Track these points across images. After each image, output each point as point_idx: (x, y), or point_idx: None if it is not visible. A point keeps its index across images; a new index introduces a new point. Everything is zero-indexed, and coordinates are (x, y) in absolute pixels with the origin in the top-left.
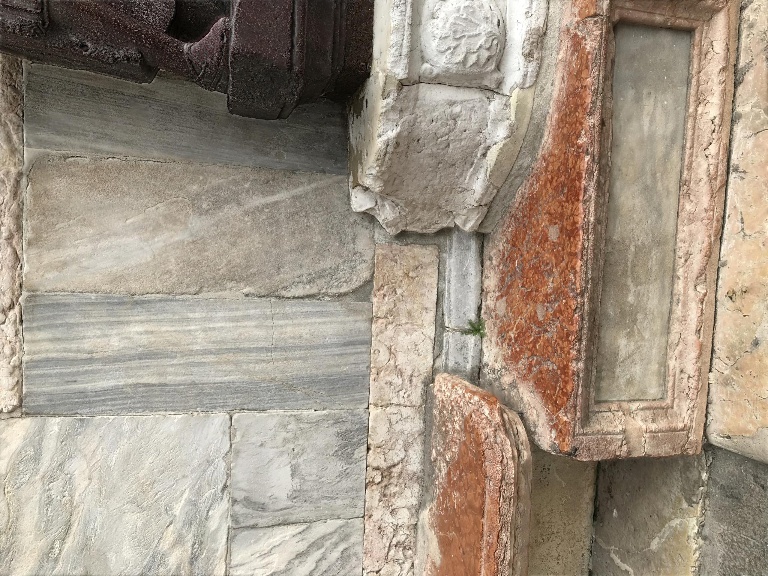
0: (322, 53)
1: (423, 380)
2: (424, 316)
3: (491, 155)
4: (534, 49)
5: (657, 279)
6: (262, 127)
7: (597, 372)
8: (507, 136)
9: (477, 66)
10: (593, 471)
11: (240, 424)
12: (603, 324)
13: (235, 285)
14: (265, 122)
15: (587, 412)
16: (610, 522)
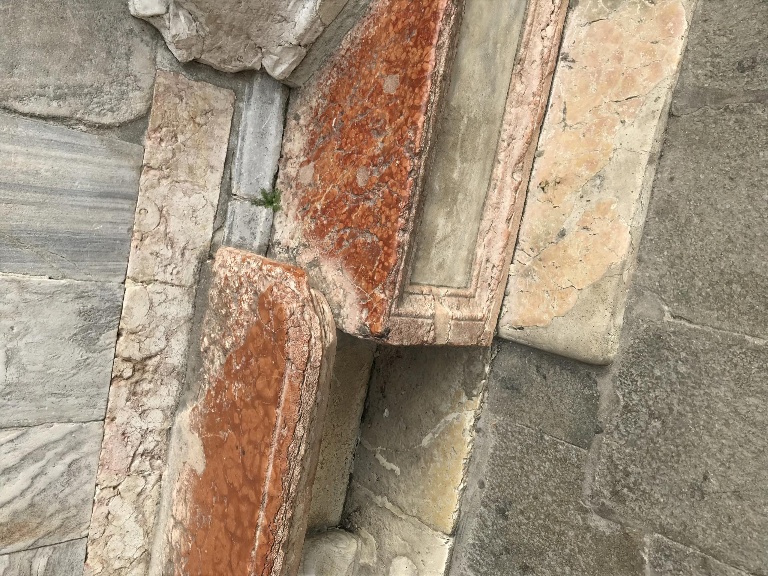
0: None
1: (198, 255)
2: (208, 176)
3: None
4: None
5: (481, 159)
6: None
7: None
8: None
9: None
10: (367, 371)
11: None
12: (428, 198)
13: None
14: None
15: (402, 292)
16: (380, 422)
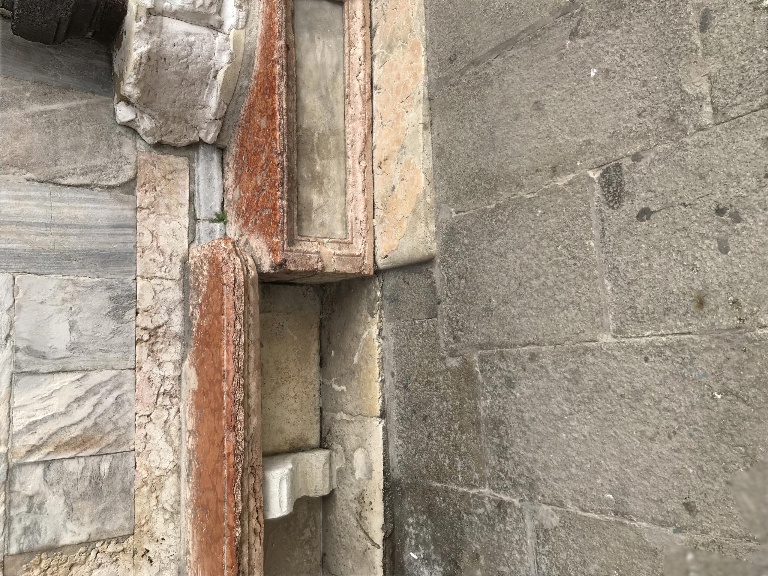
0: None
1: (181, 259)
2: (179, 210)
3: (219, 77)
4: (242, 4)
5: (335, 157)
6: (40, 53)
7: (299, 216)
8: (229, 62)
9: (203, 8)
10: (317, 329)
11: (22, 283)
12: (300, 183)
13: (17, 171)
14: (43, 50)
15: (293, 239)
16: (330, 362)
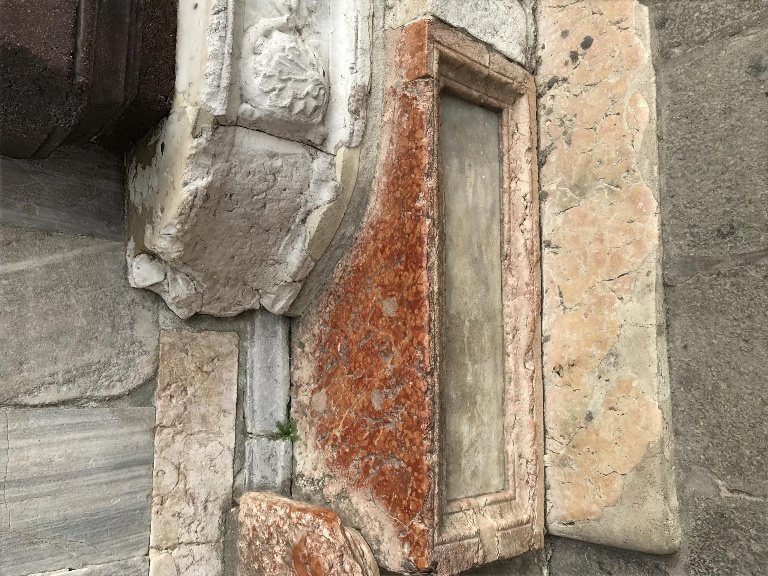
0: (112, 71)
1: (221, 505)
2: (222, 421)
3: (311, 221)
4: (359, 107)
5: (490, 357)
6: (4, 170)
7: None
8: (331, 199)
9: (303, 115)
10: None
11: None
12: (447, 409)
13: None
14: (9, 164)
15: (441, 515)
16: None
